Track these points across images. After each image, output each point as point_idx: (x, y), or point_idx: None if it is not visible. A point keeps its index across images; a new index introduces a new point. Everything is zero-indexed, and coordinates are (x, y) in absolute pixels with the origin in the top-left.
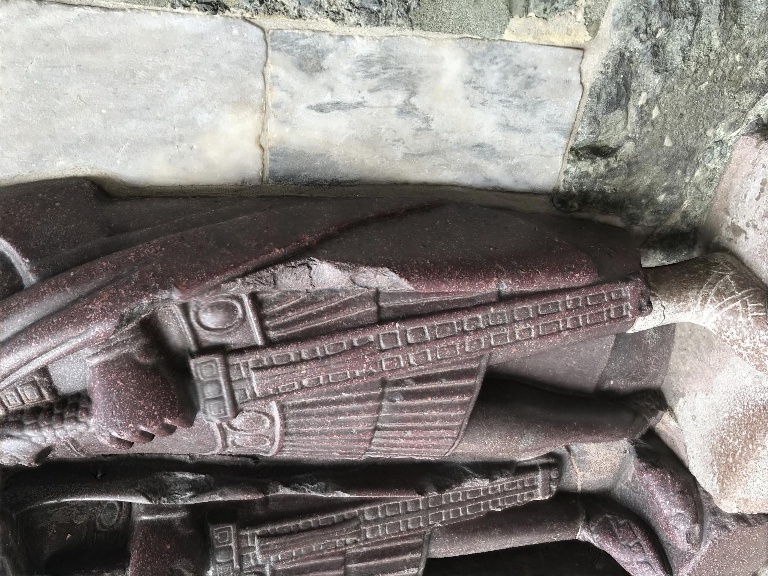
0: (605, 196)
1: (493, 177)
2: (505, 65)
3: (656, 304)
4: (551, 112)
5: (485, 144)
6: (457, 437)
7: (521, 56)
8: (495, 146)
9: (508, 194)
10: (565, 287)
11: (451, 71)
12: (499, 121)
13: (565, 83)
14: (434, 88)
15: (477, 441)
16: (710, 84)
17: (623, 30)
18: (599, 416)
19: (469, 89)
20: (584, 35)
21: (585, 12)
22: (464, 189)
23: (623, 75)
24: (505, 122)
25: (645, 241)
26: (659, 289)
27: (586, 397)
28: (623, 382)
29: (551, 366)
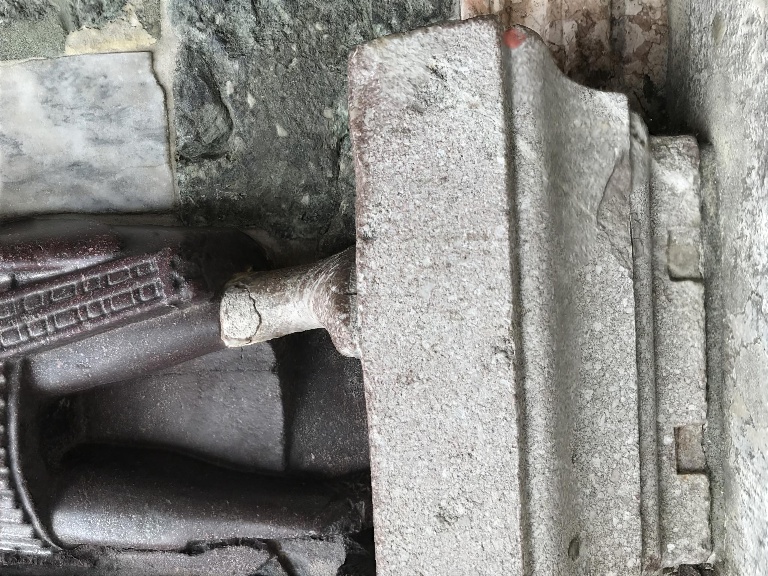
0: (233, 204)
1: (102, 198)
2: (75, 79)
3: (242, 296)
4: (137, 118)
5: (81, 162)
6: (19, 496)
7: (87, 68)
8: (92, 163)
9: (128, 217)
10: (83, 267)
11: (26, 94)
12: (87, 136)
13: (141, 86)
14: (15, 113)
15: (77, 517)
16: (300, 60)
17: (179, 24)
18: (272, 496)
19: (48, 108)
20: (147, 38)
21: (139, 17)
22: (79, 216)
23: (197, 67)
24: (94, 136)
25: (314, 260)
26: (252, 281)
27: (272, 476)
28: (330, 456)
29: (213, 428)
